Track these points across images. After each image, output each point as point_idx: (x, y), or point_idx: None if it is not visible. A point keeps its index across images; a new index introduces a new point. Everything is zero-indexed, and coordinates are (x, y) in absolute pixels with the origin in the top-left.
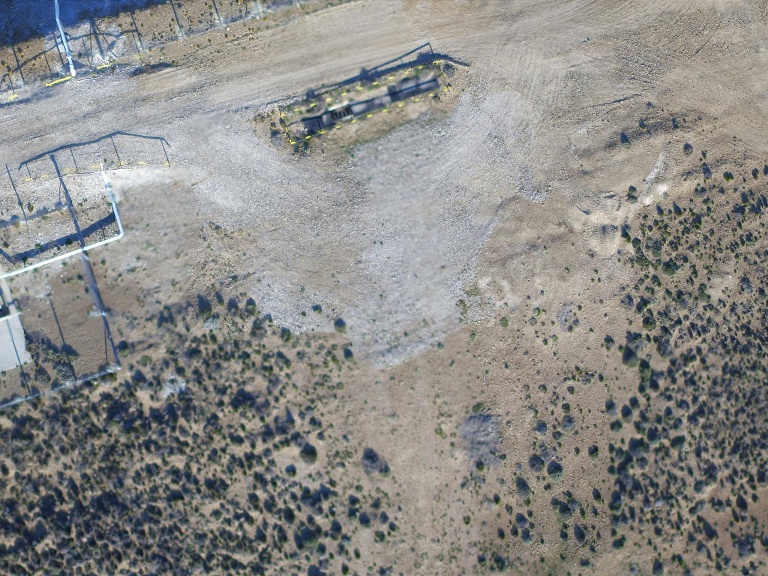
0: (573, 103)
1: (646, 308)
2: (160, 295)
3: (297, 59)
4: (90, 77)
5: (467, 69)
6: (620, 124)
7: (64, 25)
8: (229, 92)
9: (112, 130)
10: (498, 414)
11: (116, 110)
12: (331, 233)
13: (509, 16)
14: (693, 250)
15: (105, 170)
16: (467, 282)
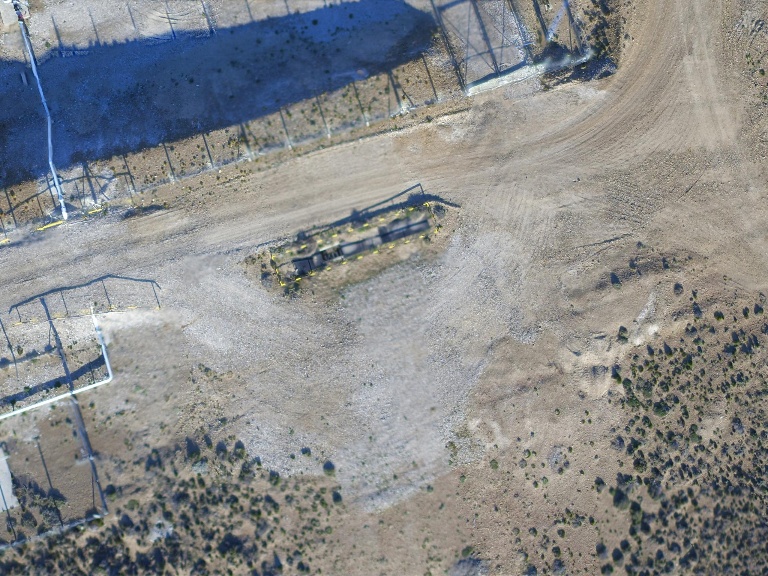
0: (563, 243)
1: (637, 450)
2: (148, 438)
3: (288, 201)
4: (82, 220)
5: (458, 210)
6: (610, 264)
7: (57, 167)
8: (220, 234)
9: (103, 273)
10: (488, 558)
11: (107, 253)
12: (321, 375)
13: (500, 157)
14: (684, 391)
15: (95, 313)
16: (457, 424)
